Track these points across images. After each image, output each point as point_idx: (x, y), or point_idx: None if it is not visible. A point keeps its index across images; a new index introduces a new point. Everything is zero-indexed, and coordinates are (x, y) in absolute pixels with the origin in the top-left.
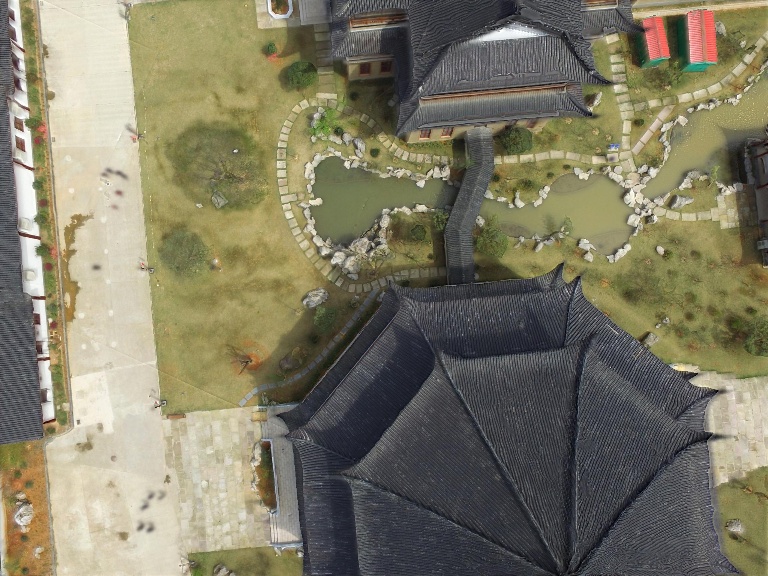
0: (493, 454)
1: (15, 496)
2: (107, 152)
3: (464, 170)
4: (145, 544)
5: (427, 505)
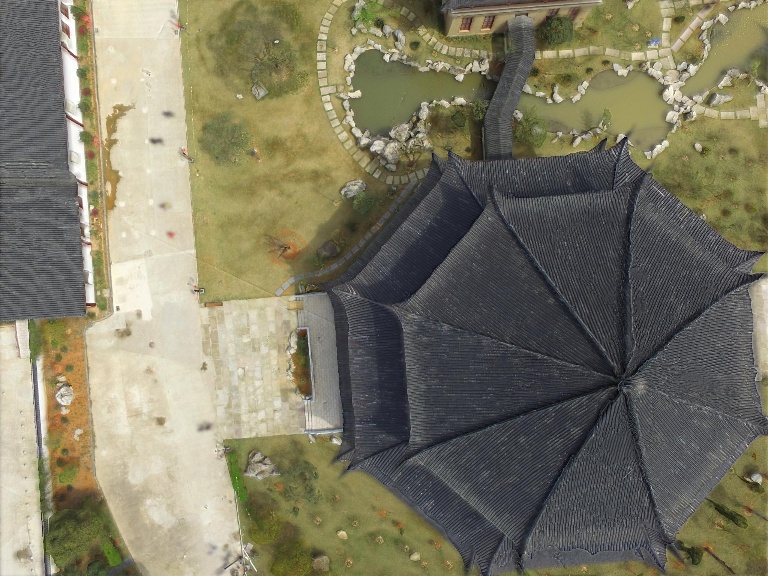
0: (547, 279)
1: (56, 378)
2: (149, 43)
3: (503, 64)
4: (181, 429)
5: (479, 332)
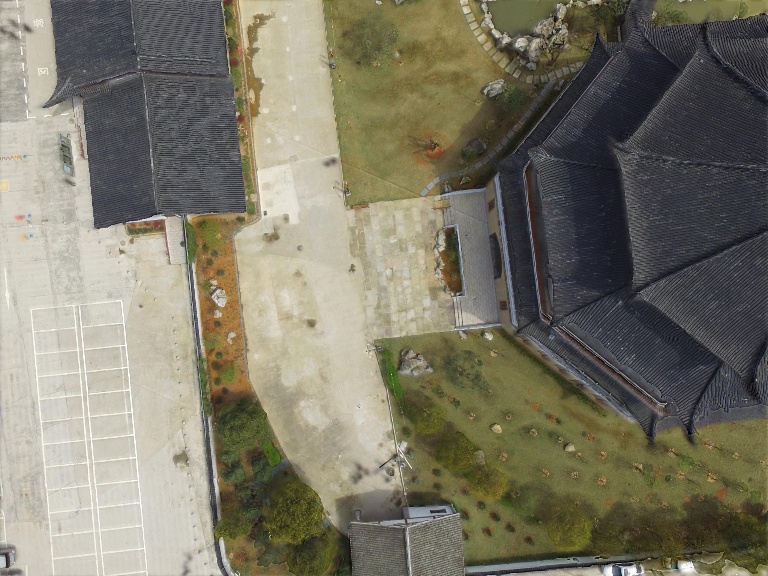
0: None
1: (208, 281)
2: None
3: None
4: (332, 330)
5: None
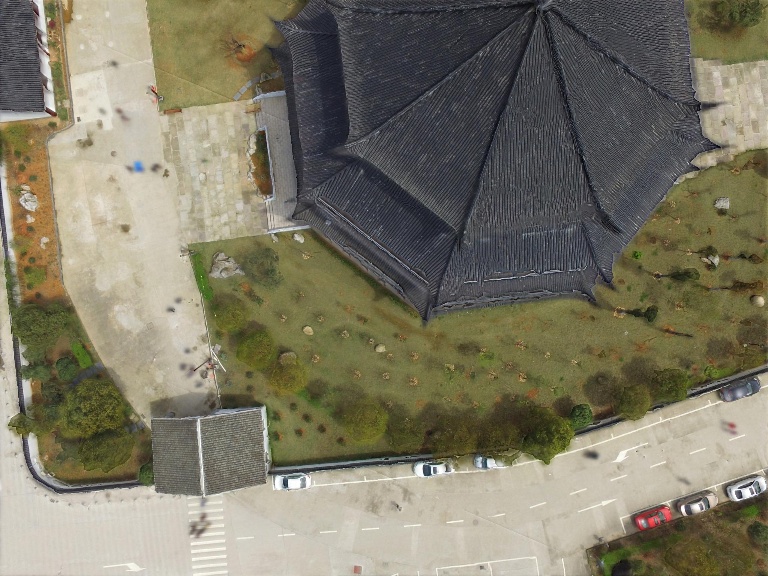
0: None
1: (19, 186)
2: None
3: None
4: (146, 235)
5: None
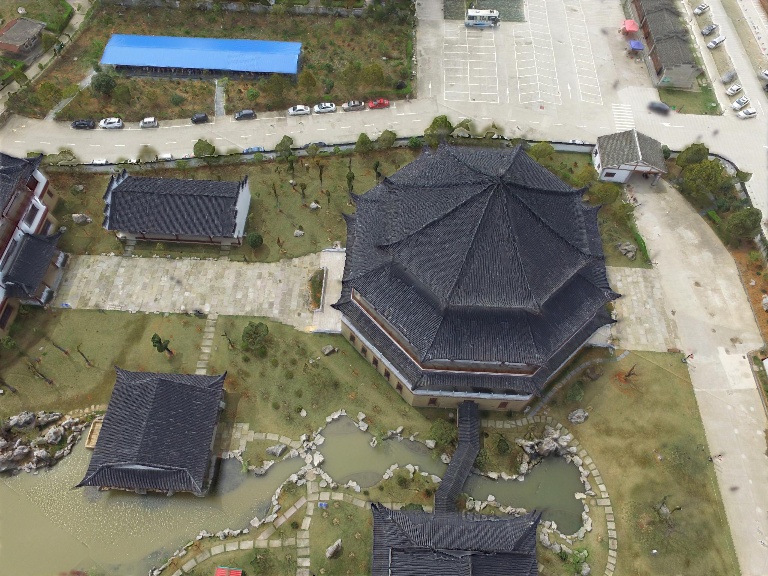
0: None
1: None
2: None
3: None
4: (683, 278)
5: (553, 233)
